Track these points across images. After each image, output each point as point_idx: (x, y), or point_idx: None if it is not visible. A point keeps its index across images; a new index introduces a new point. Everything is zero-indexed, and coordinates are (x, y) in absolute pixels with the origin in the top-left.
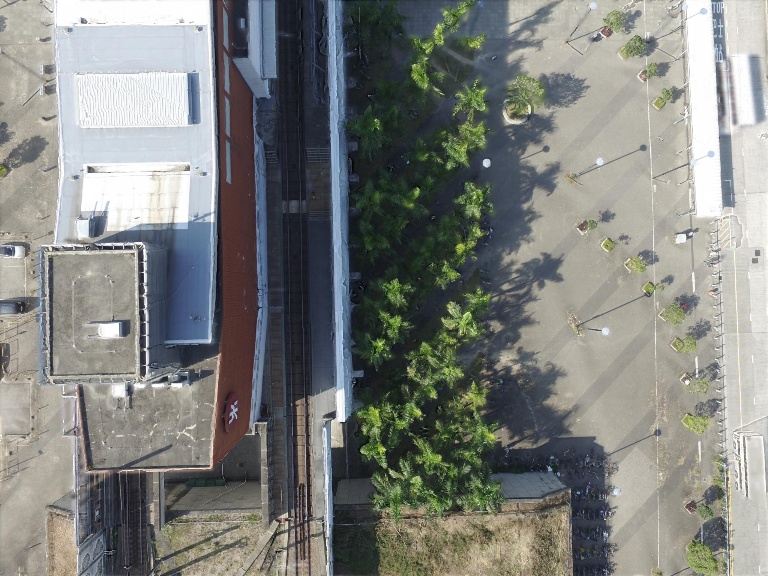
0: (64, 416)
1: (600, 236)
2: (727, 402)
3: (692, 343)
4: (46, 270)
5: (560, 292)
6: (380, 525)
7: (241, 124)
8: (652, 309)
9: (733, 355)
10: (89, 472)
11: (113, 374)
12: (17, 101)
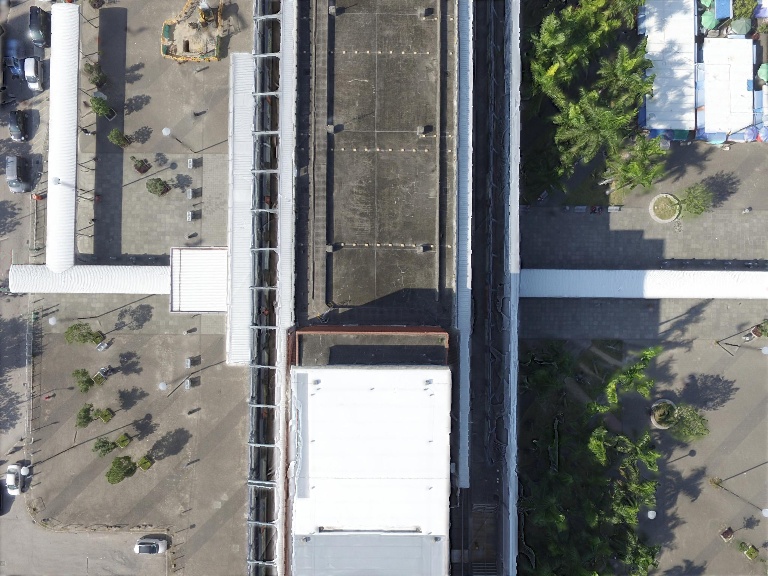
0: None
1: None
2: None
3: None
4: None
5: None
6: None
7: None
8: None
9: None
10: None
11: None
12: (162, 392)
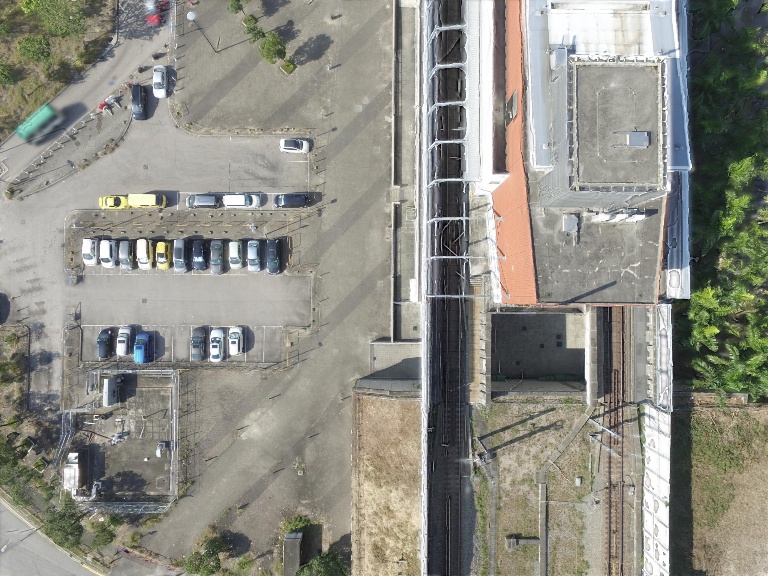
0: (344, 309)
1: None
2: None
3: None
4: (574, 79)
5: None
6: (694, 412)
7: None
8: None
9: None
10: (539, 304)
11: (637, 183)
12: None
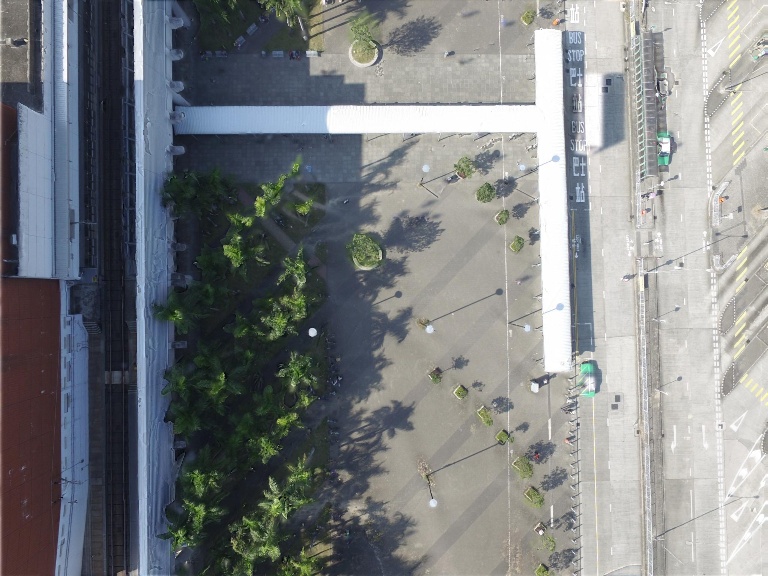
0: None
1: (453, 383)
2: (583, 552)
3: (538, 501)
4: None
5: (411, 441)
6: None
7: (25, 330)
8: (506, 457)
9: (590, 504)
10: None
11: None
12: None
